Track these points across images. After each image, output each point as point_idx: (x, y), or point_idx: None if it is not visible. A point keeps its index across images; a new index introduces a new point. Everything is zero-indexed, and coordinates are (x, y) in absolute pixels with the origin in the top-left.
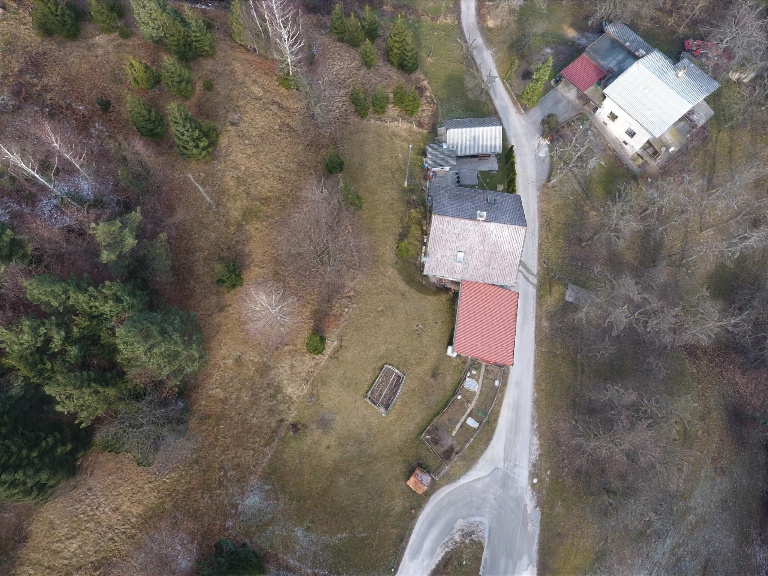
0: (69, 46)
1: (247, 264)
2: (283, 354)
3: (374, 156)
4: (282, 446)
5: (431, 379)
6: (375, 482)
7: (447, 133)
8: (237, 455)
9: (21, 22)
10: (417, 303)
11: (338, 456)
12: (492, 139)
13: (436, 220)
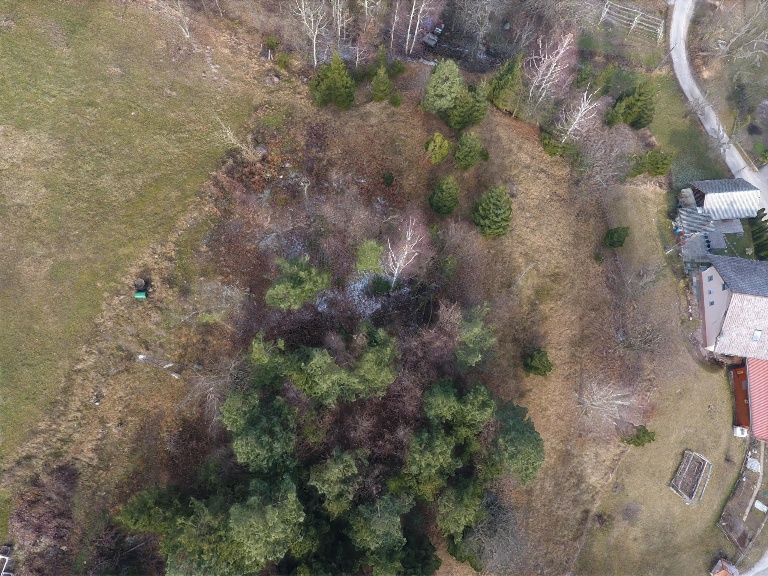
0: (343, 115)
1: (543, 346)
2: (587, 442)
3: (637, 223)
4: (591, 539)
5: (726, 463)
6: (680, 575)
7: (705, 198)
8: (549, 550)
9: (295, 91)
10: (707, 382)
11: (644, 548)
12: (749, 203)
13: (736, 298)
